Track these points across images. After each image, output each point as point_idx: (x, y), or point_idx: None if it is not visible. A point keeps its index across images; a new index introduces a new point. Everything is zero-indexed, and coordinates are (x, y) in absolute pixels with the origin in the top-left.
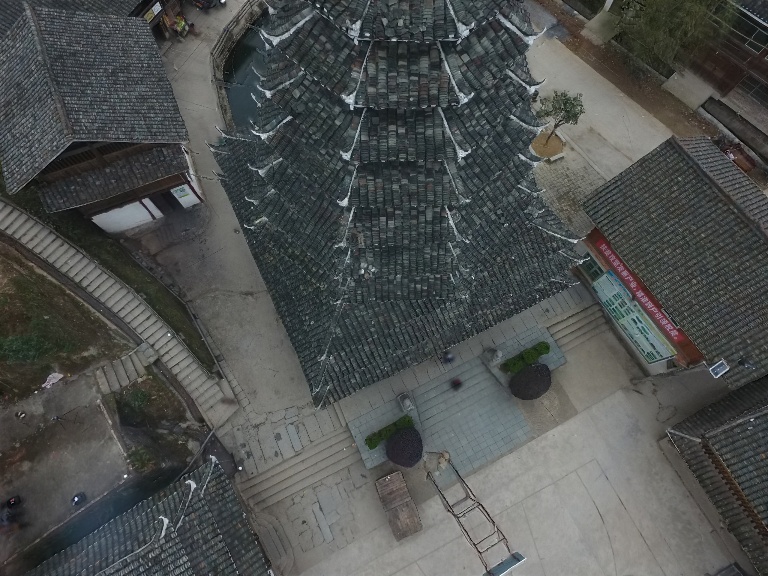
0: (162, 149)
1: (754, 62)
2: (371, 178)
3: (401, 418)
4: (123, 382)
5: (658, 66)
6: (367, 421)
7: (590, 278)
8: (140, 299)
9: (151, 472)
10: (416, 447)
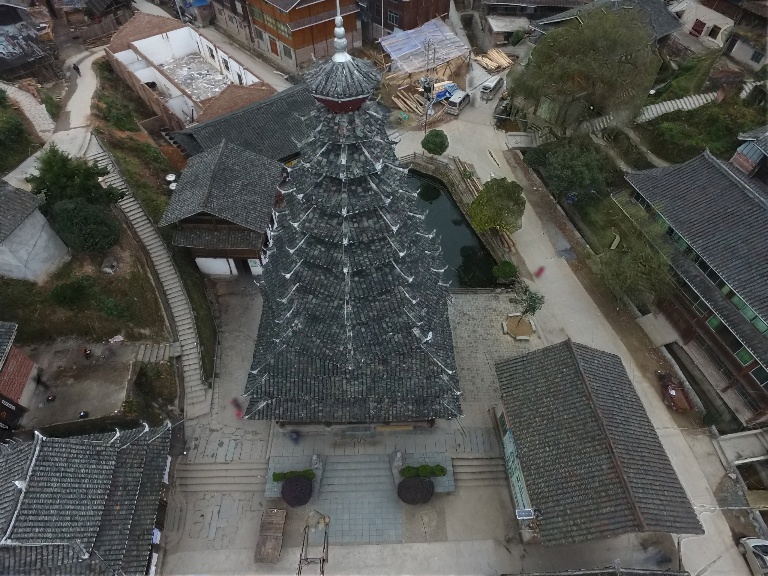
0: (251, 233)
1: (699, 323)
2: (306, 269)
3: (306, 470)
4: (152, 359)
5: (638, 304)
6: (284, 462)
7: (503, 434)
8: (191, 313)
9: (131, 420)
10: (303, 492)
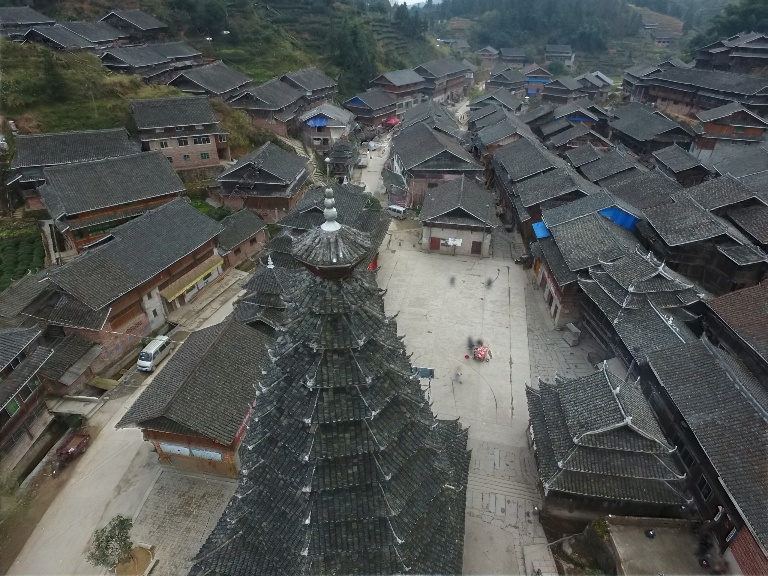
0: None
1: None
2: None
3: None
4: None
5: None
6: None
7: None
8: None
9: None
10: None
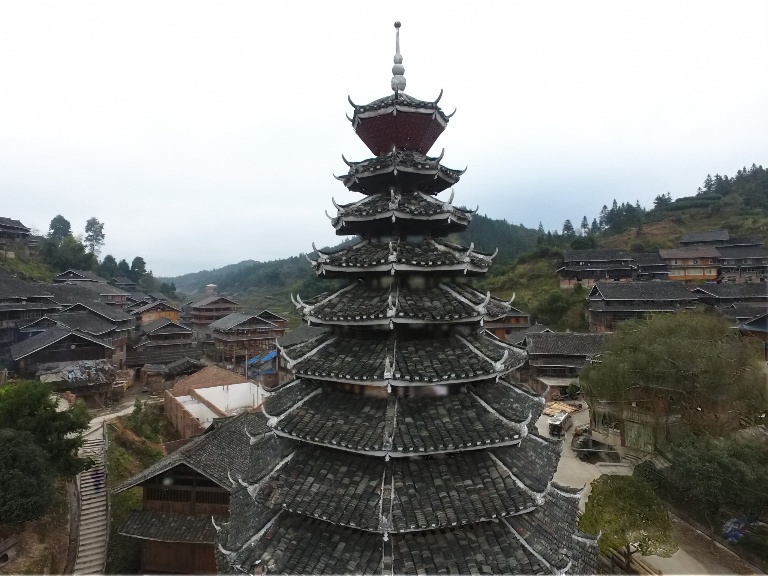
0: None
1: None
2: (311, 412)
3: None
4: None
5: None
6: None
7: None
8: None
9: None
10: None
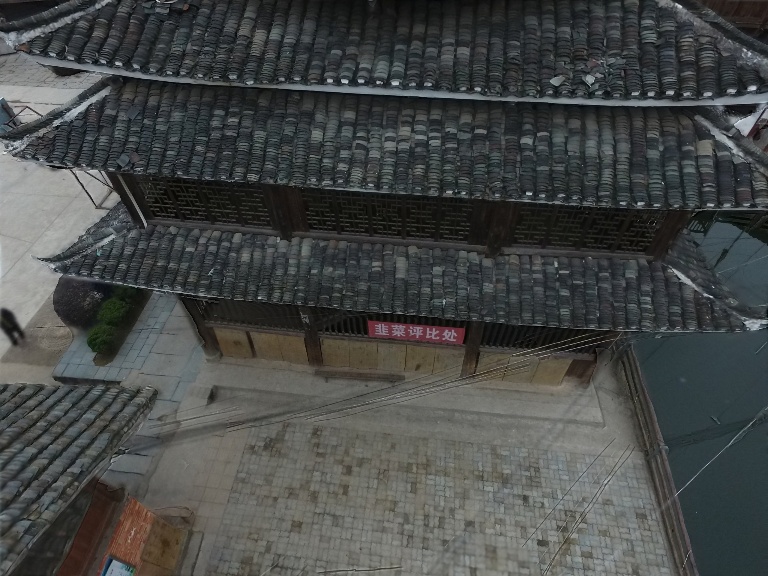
0: None
1: None
2: None
3: None
4: None
5: None
6: None
7: None
8: None
9: None
10: None
